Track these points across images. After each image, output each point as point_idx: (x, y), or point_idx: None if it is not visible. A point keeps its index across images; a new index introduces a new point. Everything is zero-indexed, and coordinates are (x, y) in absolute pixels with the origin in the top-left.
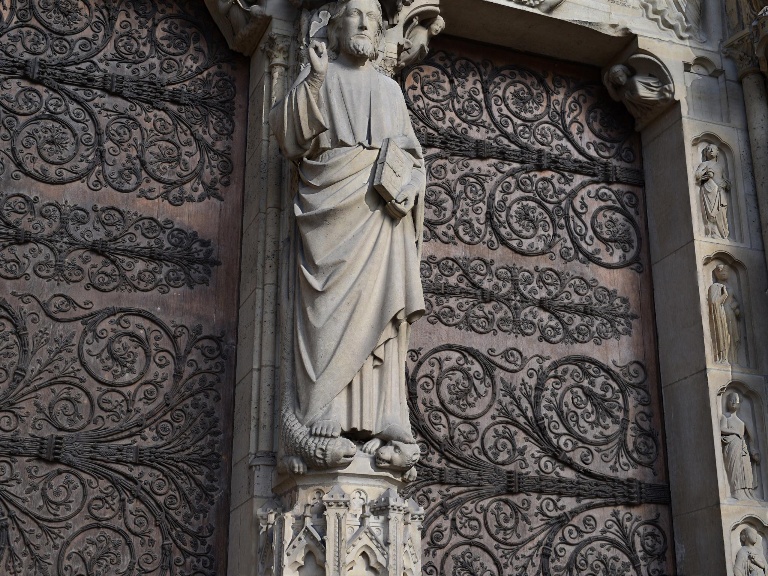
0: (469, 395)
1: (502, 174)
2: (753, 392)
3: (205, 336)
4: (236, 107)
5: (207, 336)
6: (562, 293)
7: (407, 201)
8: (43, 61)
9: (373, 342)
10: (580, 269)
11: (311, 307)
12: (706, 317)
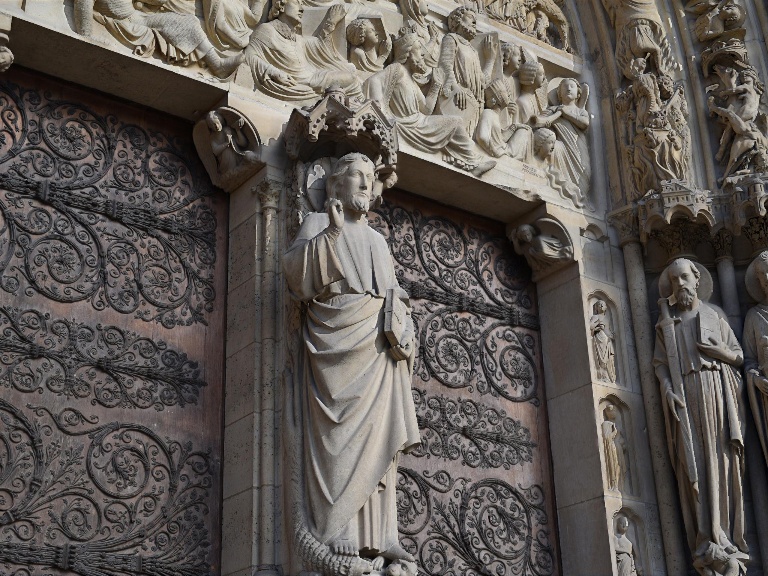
0: (409, 512)
1: (431, 313)
2: (637, 517)
3: (195, 452)
4: (217, 238)
5: (197, 452)
6: (479, 422)
7: (408, 346)
8: (54, 184)
9: (382, 470)
10: (492, 401)
11: (327, 436)
12: (602, 451)
